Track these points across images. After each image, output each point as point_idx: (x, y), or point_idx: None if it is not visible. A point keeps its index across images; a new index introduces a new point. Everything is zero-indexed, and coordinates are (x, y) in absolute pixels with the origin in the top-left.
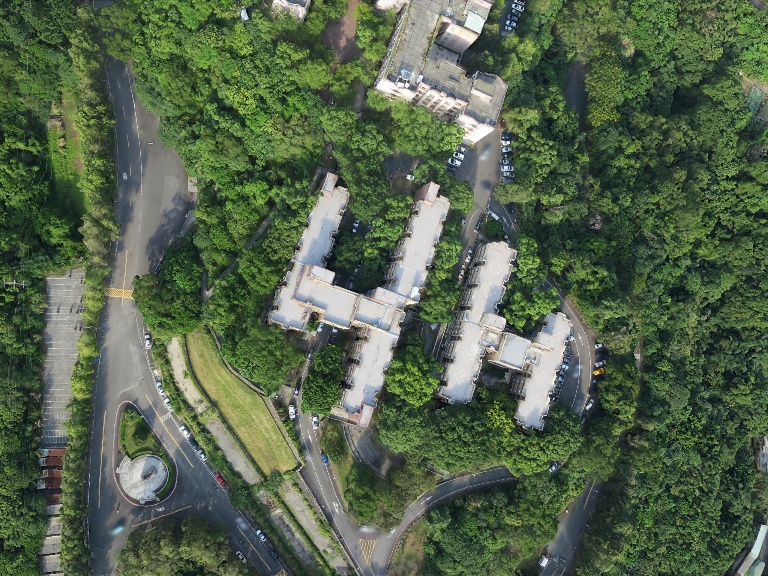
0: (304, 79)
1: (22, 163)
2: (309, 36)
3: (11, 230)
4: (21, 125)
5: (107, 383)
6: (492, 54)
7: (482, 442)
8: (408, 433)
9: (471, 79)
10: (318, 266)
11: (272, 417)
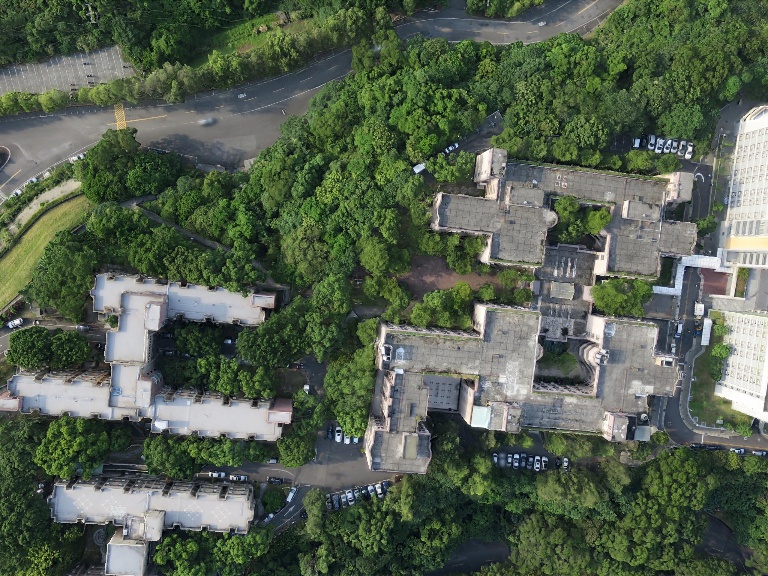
0: (365, 245)
1: None
2: (416, 240)
3: (156, 1)
4: None
5: (24, 129)
6: None
7: (7, 548)
8: (2, 458)
9: (423, 429)
10: (161, 310)
11: (8, 303)
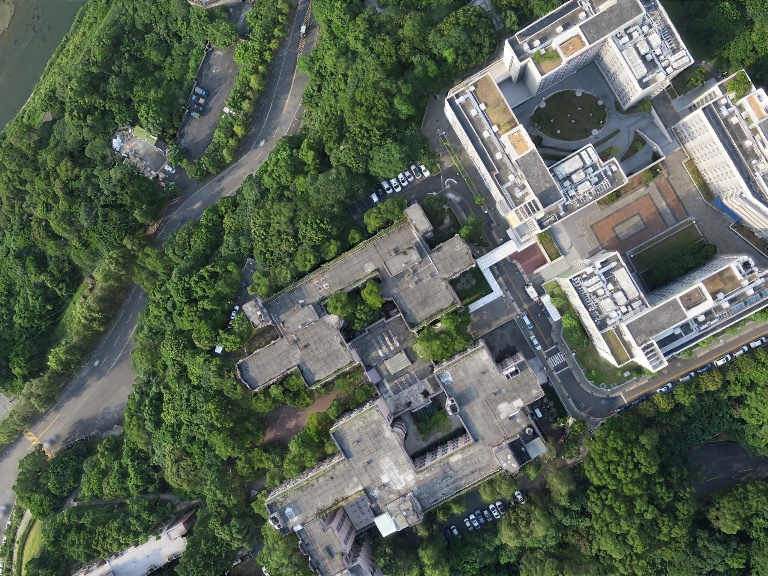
0: (214, 441)
1: (42, 298)
2: (250, 408)
3: None
4: (63, 270)
5: None
6: (401, 550)
7: None
8: None
9: (357, 557)
10: None
11: None
